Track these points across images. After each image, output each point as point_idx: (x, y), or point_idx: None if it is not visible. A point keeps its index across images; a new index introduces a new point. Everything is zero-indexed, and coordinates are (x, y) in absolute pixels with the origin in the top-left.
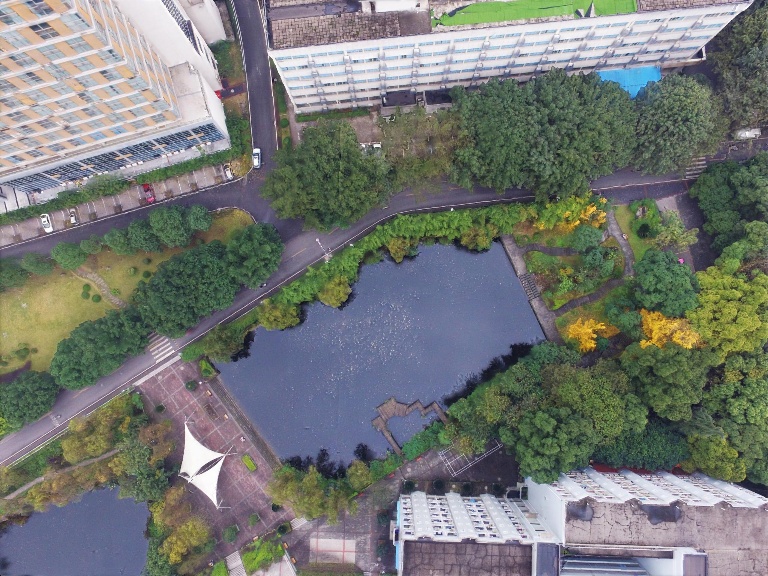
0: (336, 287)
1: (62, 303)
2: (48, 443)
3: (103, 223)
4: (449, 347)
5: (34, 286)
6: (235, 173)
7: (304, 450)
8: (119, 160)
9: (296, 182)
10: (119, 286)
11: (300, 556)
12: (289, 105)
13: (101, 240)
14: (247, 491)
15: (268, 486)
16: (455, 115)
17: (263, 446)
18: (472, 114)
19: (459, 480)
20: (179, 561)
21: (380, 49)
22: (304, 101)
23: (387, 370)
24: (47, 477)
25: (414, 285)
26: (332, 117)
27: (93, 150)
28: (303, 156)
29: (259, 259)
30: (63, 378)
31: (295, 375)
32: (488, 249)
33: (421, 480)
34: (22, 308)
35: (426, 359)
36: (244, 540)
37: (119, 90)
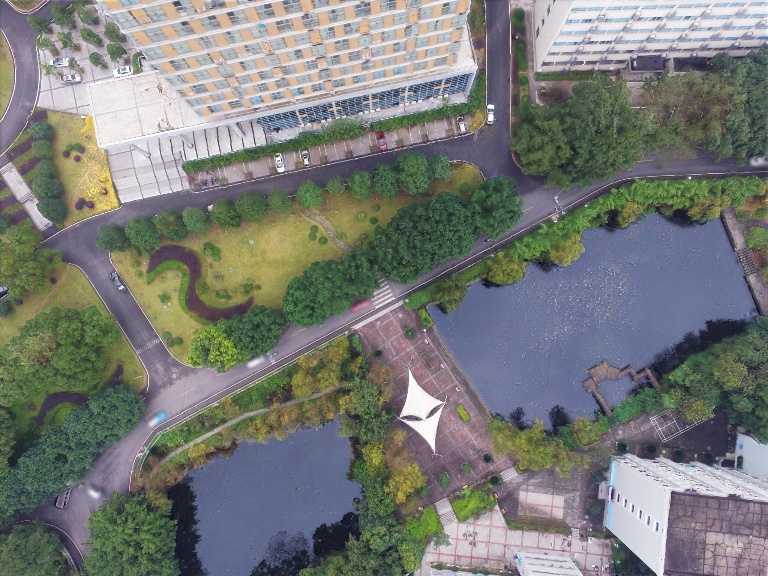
0: (574, 245)
1: (289, 243)
2: (264, 379)
3: (333, 167)
4: (663, 315)
5: (262, 224)
6: (467, 127)
7: (498, 408)
8: (364, 105)
9: (561, 136)
10: (345, 230)
11: (509, 507)
12: (529, 63)
13: (345, 181)
14: (458, 440)
15: (501, 434)
16: (728, 80)
17: (475, 398)
18: (744, 81)
19: (669, 446)
20: (404, 501)
21: (675, 7)
22: (554, 59)
23: (600, 333)
24: (275, 410)
25: (632, 252)
26: (571, 78)
27: (360, 90)
28: (577, 110)
29: (505, 211)
30: (298, 314)
31: (509, 331)
32: (706, 222)
33: (632, 443)
34: (249, 244)
35: (640, 325)
36: (453, 488)
37: (439, 26)
